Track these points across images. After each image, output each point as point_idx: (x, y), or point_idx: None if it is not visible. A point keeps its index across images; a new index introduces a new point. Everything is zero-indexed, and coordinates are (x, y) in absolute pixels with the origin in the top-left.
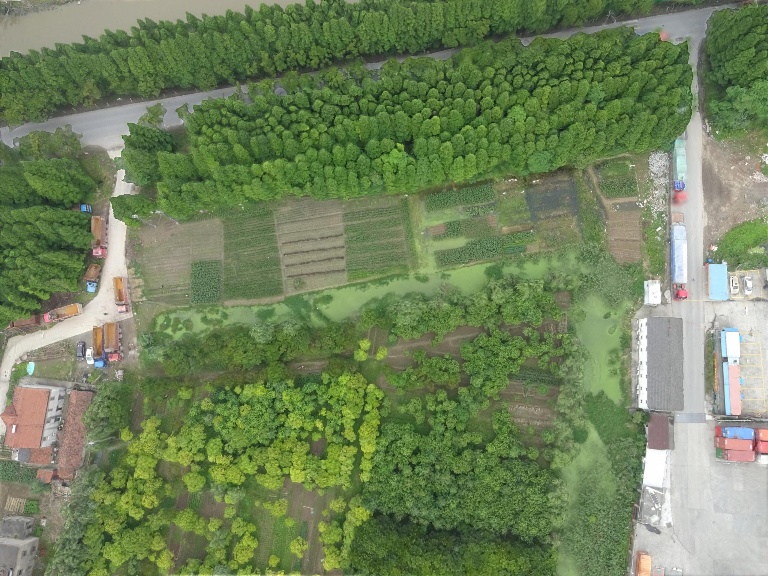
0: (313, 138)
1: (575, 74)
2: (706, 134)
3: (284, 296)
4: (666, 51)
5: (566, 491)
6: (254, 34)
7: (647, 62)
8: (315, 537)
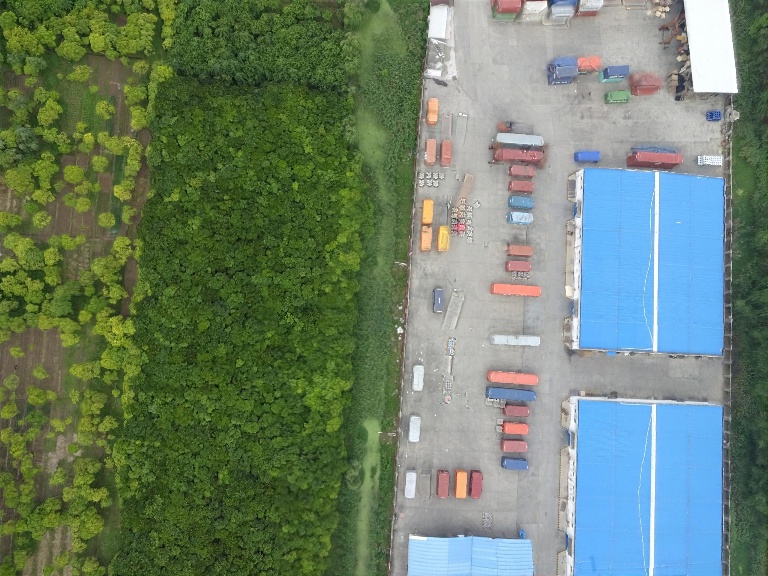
0: None
1: None
2: None
3: None
4: None
5: (356, 38)
6: None
7: None
8: (124, 109)
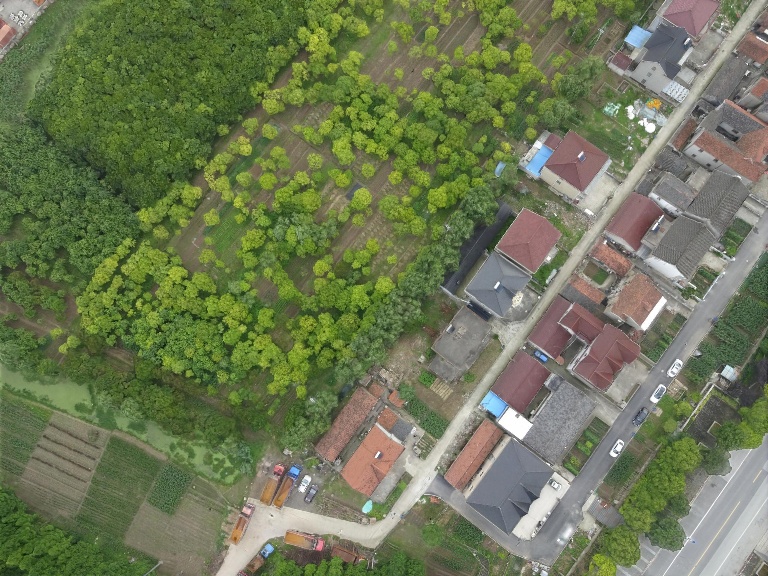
0: None
1: None
2: None
3: (112, 433)
4: None
5: None
6: None
7: None
8: (203, 219)
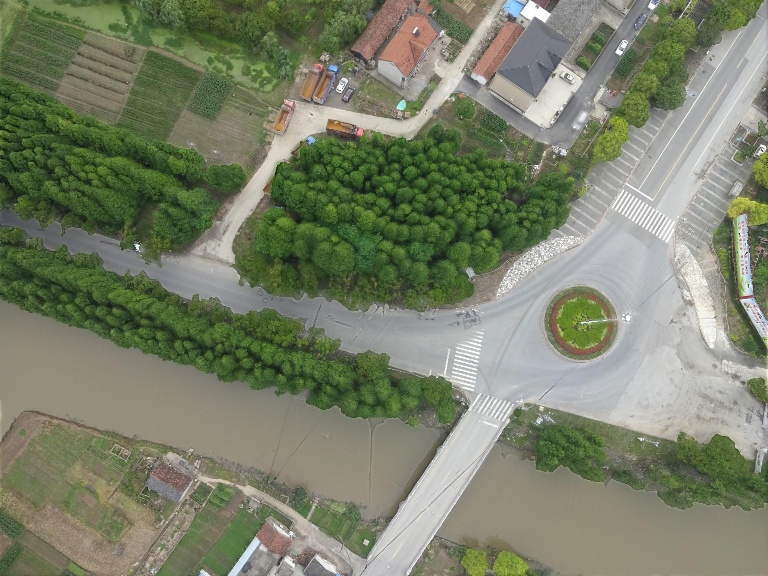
0: (4, 121)
1: None
2: None
3: (149, 49)
4: None
5: None
6: None
7: None
8: None
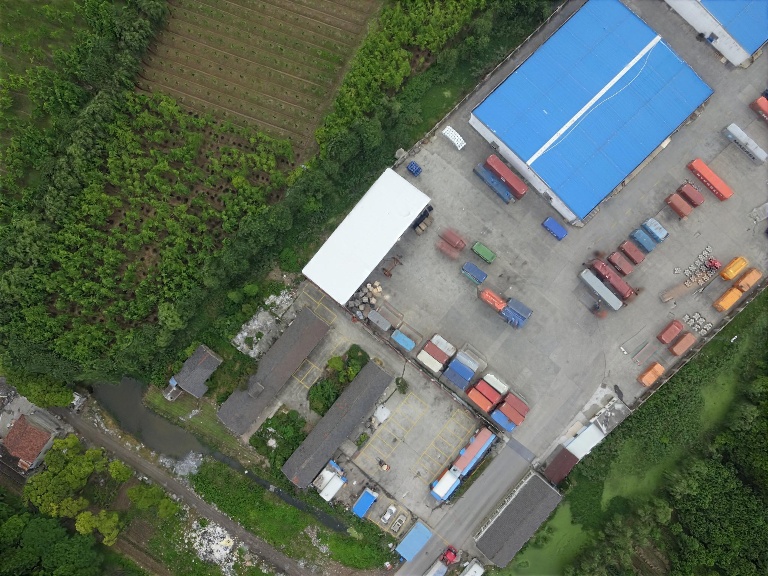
0: None
1: None
2: None
3: None
4: None
5: (679, 487)
6: None
7: None
8: None
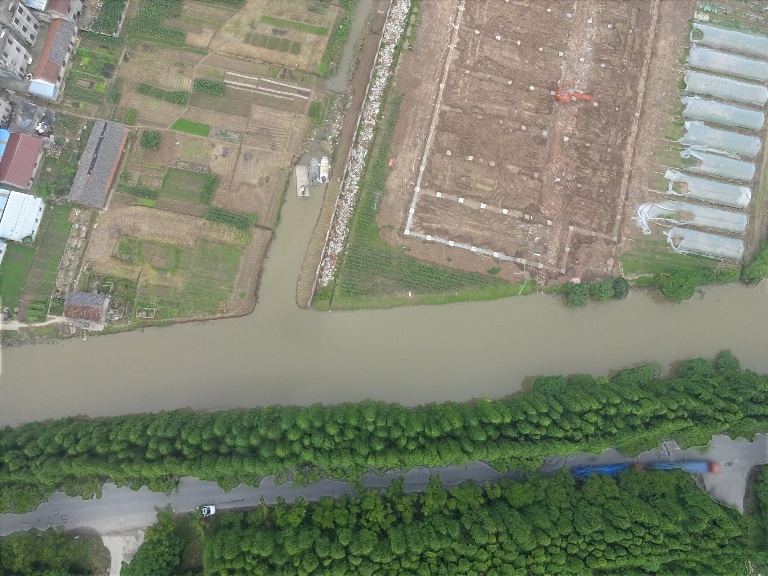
0: None
1: (633, 549)
2: (748, 575)
3: None
4: (727, 531)
5: None
6: (289, 455)
7: (707, 543)
8: None
